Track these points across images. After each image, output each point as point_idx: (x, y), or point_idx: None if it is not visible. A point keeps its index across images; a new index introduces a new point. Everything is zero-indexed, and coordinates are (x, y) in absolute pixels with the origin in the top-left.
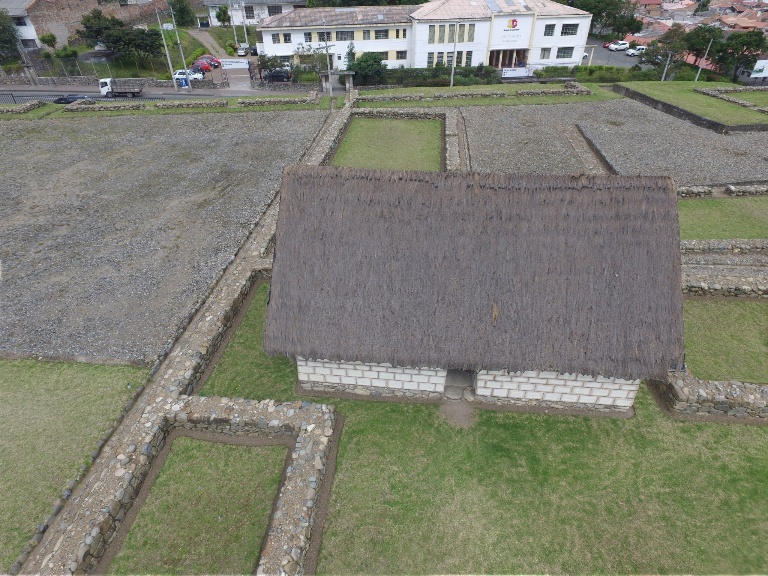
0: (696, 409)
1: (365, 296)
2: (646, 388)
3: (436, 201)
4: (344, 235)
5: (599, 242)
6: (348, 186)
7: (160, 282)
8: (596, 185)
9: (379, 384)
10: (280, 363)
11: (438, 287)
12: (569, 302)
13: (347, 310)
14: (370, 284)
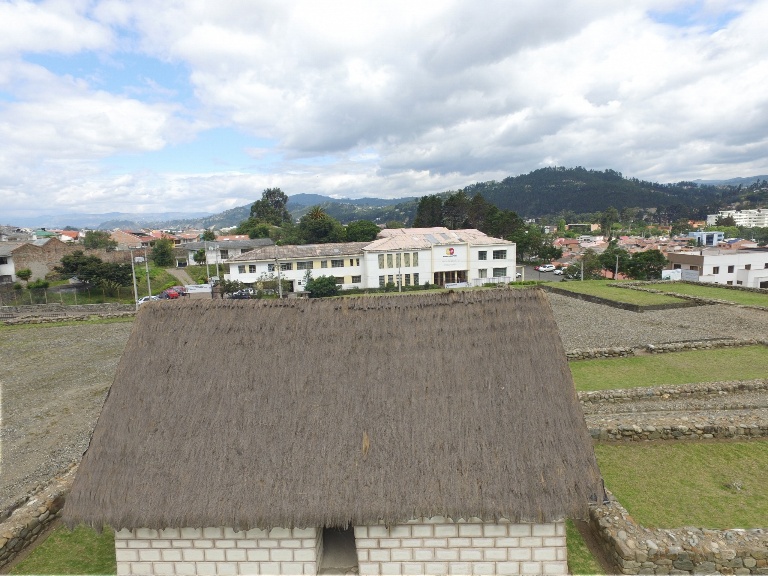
0: (652, 572)
1: (208, 435)
2: (587, 551)
3: (301, 325)
4: (195, 366)
5: (478, 354)
6: (208, 316)
7: (1, 470)
8: (467, 299)
9: (227, 571)
10: (108, 558)
11: (297, 417)
12: (453, 424)
13: (183, 454)
14: (216, 420)
